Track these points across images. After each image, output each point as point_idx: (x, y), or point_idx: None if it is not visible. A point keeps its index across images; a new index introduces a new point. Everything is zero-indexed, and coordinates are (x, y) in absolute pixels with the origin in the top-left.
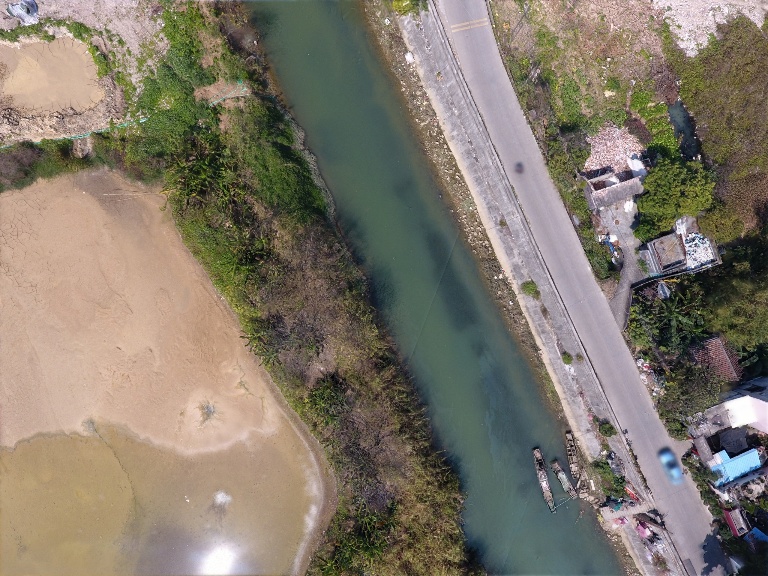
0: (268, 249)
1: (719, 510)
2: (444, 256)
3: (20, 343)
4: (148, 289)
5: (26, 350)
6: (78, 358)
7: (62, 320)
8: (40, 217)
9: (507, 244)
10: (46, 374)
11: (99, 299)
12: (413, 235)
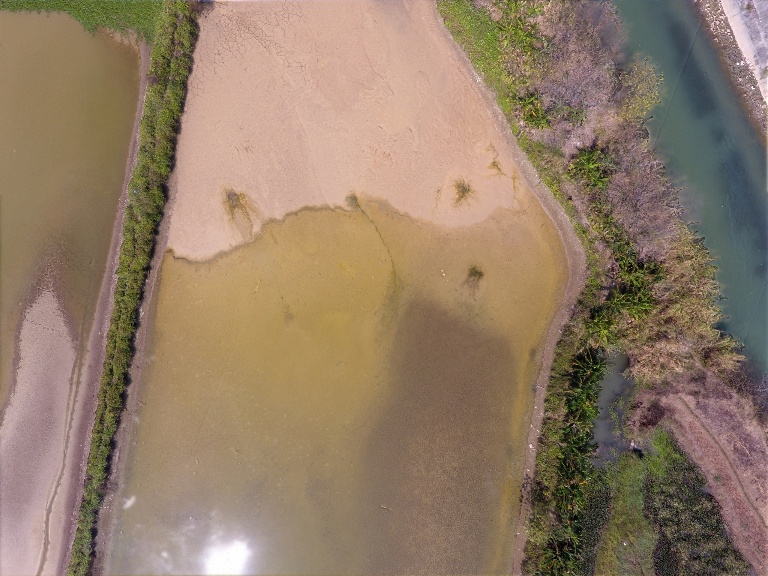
0: None
1: None
2: (687, 44)
3: (290, 120)
4: (408, 72)
5: (295, 127)
6: (343, 136)
7: (328, 99)
8: (309, 1)
9: (753, 28)
10: (313, 150)
11: (363, 80)
12: (657, 24)
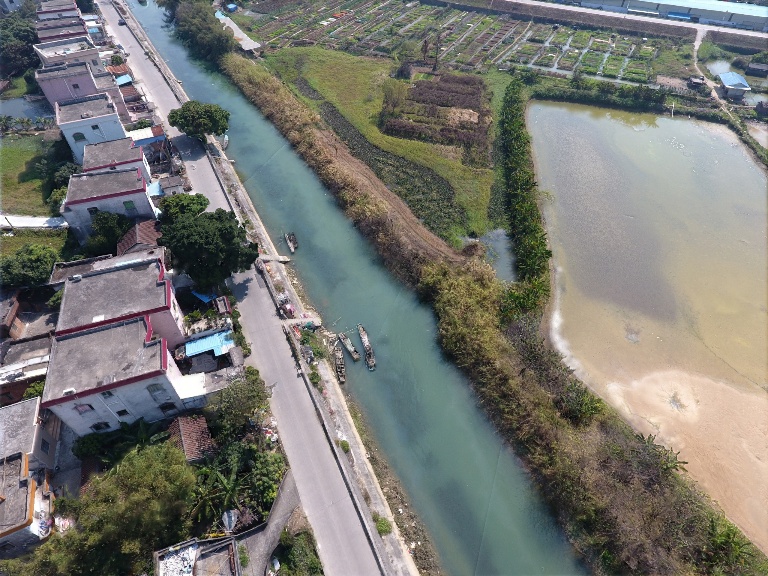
0: (701, 573)
1: (234, 314)
2: (483, 573)
3: None
4: None
5: None
6: None
7: None
8: None
9: None
10: None
11: None
12: None
